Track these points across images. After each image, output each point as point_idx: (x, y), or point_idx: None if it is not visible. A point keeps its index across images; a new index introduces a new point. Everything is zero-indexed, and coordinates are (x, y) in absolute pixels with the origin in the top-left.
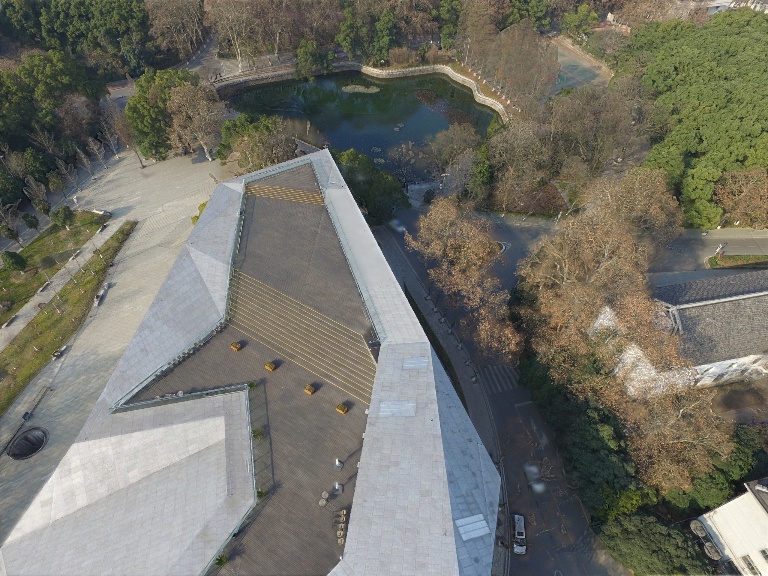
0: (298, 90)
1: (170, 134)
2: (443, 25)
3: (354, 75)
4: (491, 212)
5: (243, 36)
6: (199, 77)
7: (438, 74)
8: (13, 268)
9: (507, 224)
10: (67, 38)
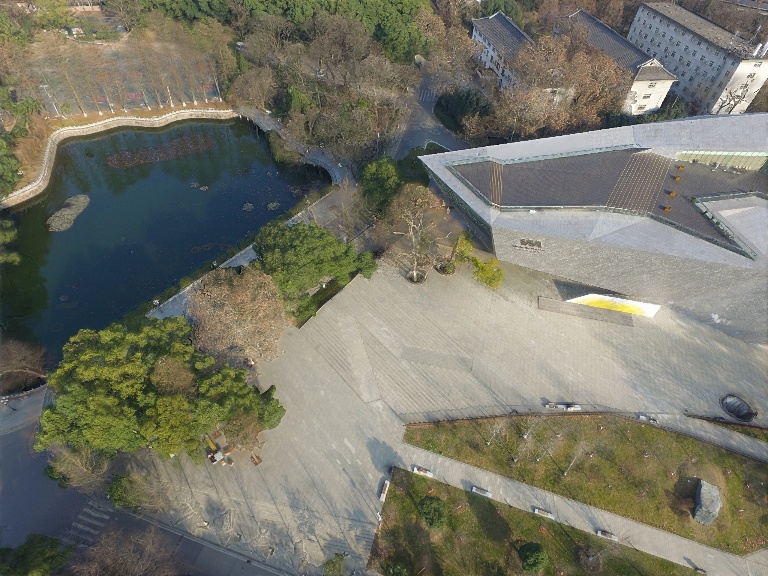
0: (1, 293)
1: None
2: None
3: None
4: None
5: None
6: None
7: (60, 144)
8: None
9: (403, 137)
10: None
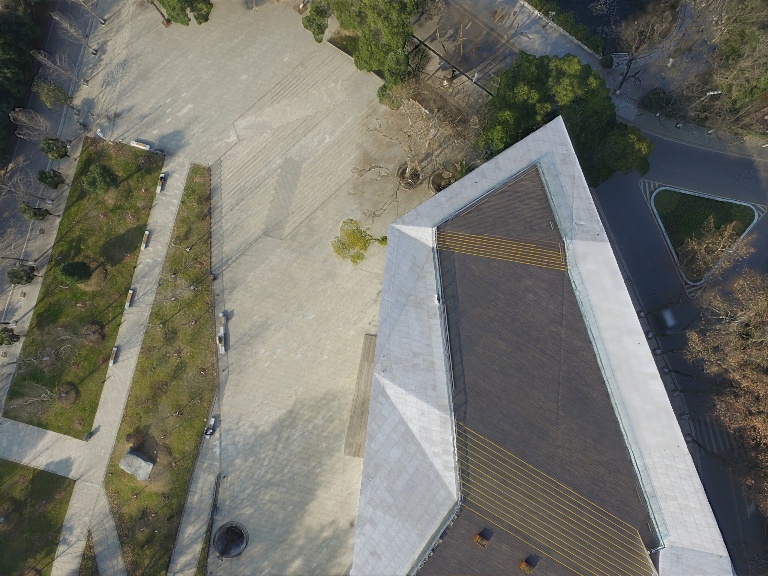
0: None
1: None
2: None
3: None
4: (748, 136)
5: None
6: None
7: None
8: (78, 282)
9: (767, 163)
10: None
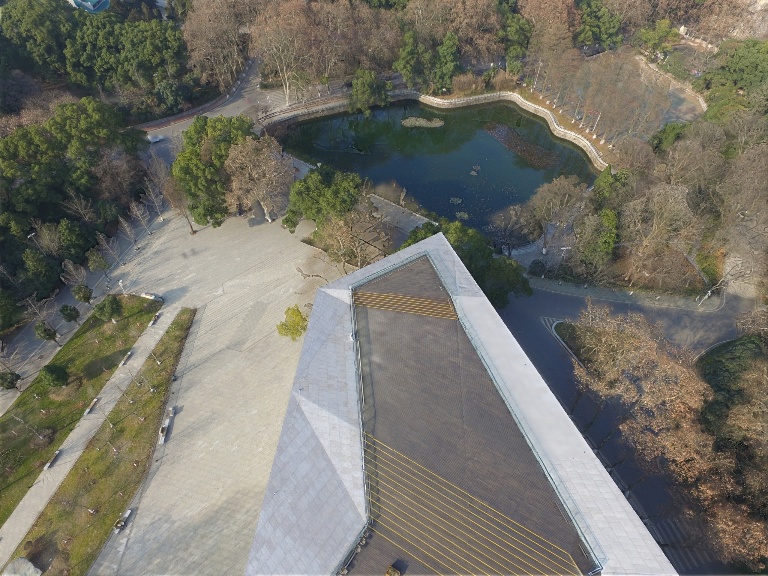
0: (351, 124)
1: (229, 199)
2: (509, 46)
3: (410, 104)
4: (615, 288)
5: (293, 67)
6: (253, 123)
7: (504, 101)
8: (53, 385)
9: (638, 304)
10: (94, 72)
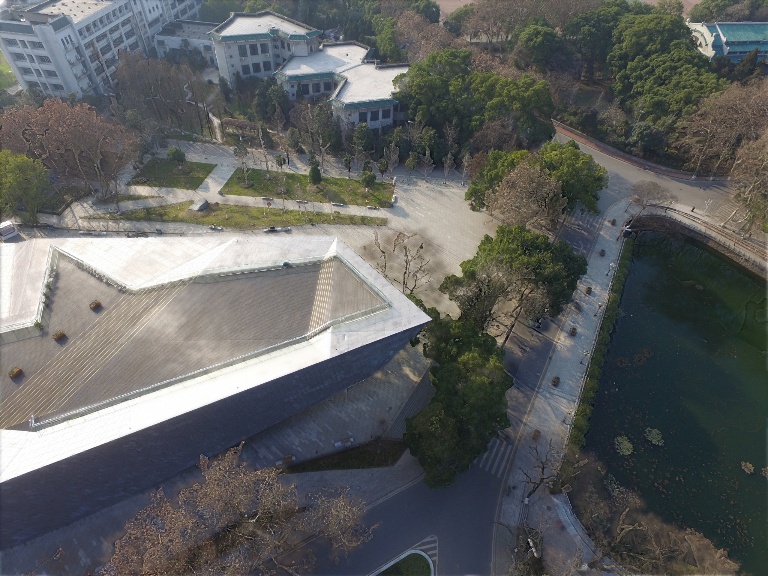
0: (762, 301)
1: (486, 195)
2: None
3: None
4: None
5: (761, 193)
6: (607, 182)
7: None
8: None
9: None
10: (632, 89)
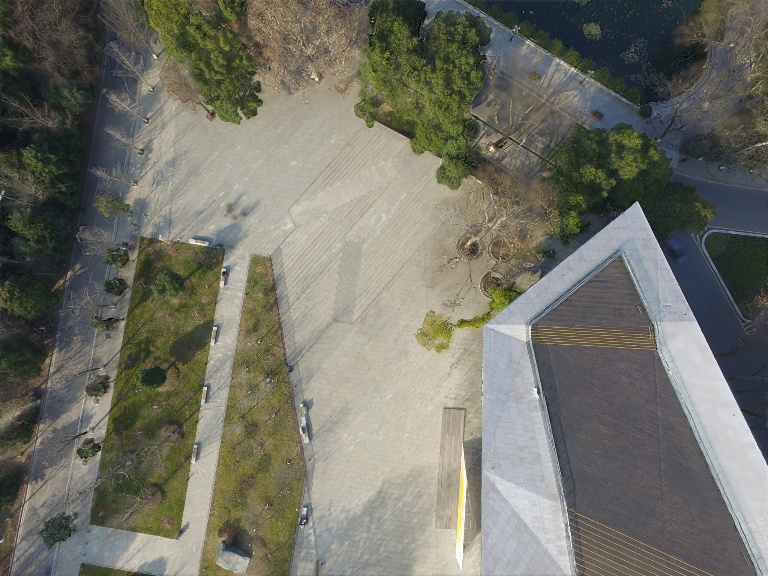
0: None
1: None
2: None
3: None
4: None
5: None
6: None
7: None
8: None
9: None
10: None
